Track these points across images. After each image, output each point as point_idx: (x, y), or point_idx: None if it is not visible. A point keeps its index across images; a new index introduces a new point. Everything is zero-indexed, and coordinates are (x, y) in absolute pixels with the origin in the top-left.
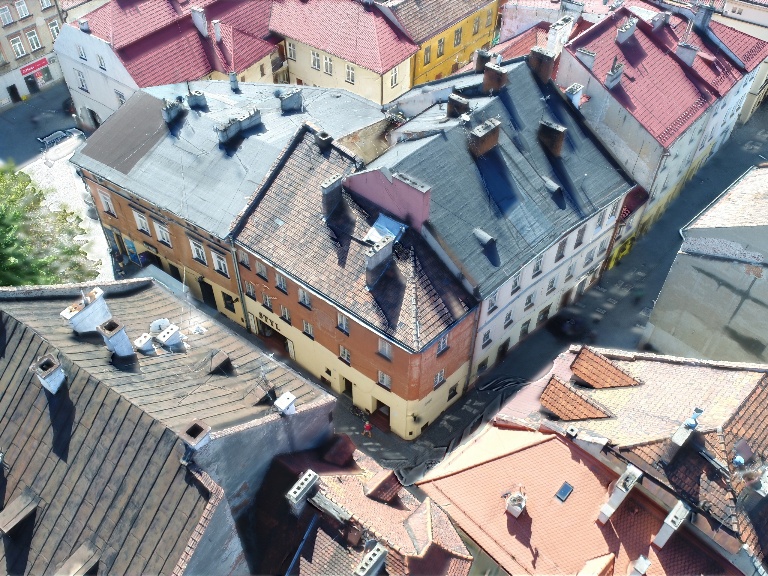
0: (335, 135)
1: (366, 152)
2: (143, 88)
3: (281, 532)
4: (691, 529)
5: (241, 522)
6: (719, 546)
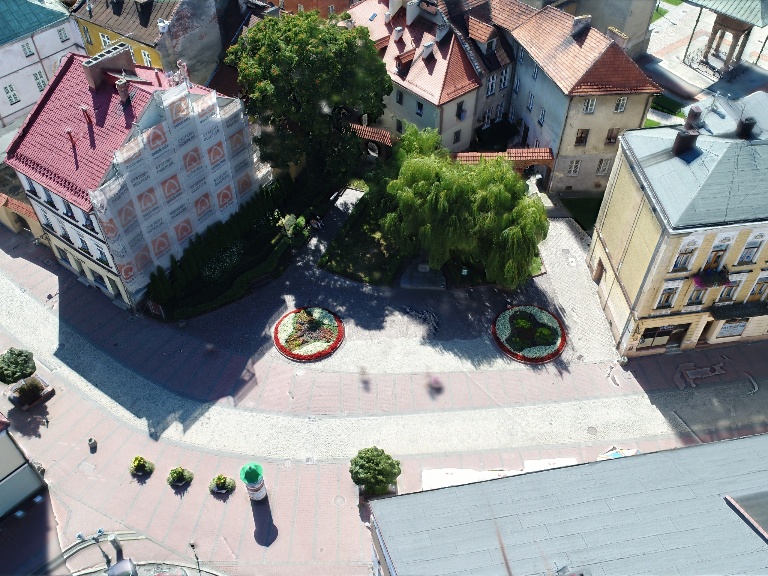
0: None
1: None
2: None
3: (236, 23)
4: (423, 16)
5: (218, 20)
6: (432, 16)
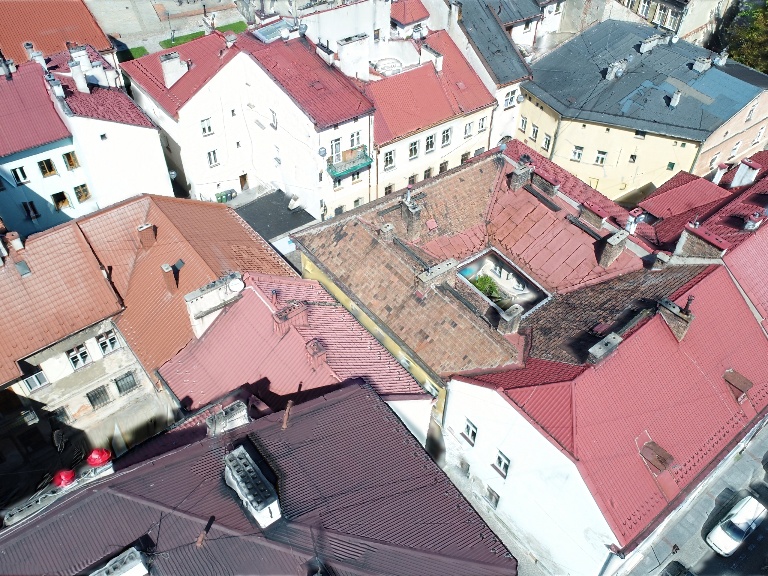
0: (579, 43)
1: (553, 45)
2: (761, 91)
3: None
4: None
5: None
6: None
